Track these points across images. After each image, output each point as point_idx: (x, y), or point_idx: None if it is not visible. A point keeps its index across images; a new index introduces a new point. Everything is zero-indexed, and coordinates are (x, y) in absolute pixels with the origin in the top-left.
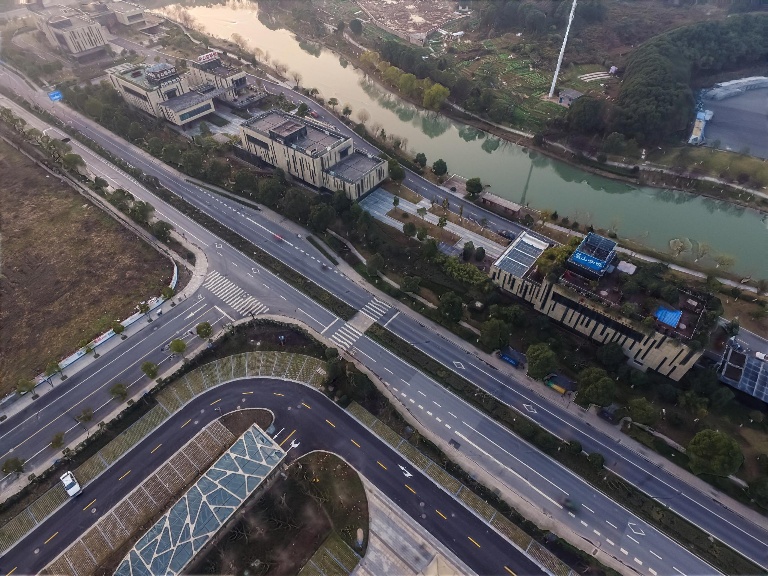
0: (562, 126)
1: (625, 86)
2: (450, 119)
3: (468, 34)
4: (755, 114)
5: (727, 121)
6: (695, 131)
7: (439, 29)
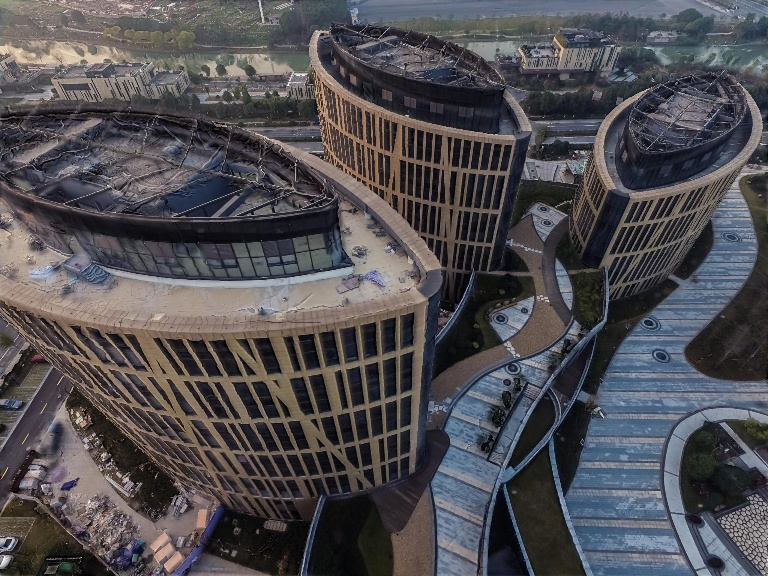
0: (281, 34)
1: (304, 2)
2: (204, 55)
3: (179, 4)
4: (378, 6)
5: (367, 12)
6: (353, 18)
7: (152, 7)
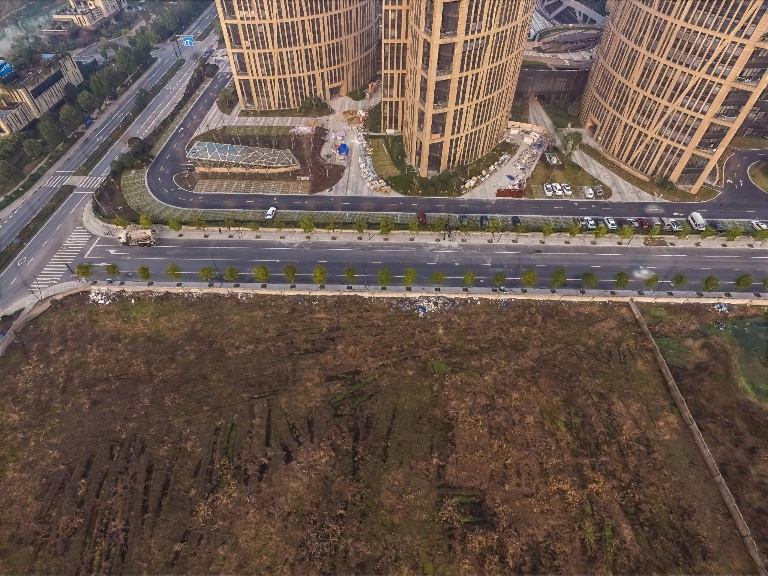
0: None
1: None
2: None
3: None
4: None
5: None
6: None
7: None
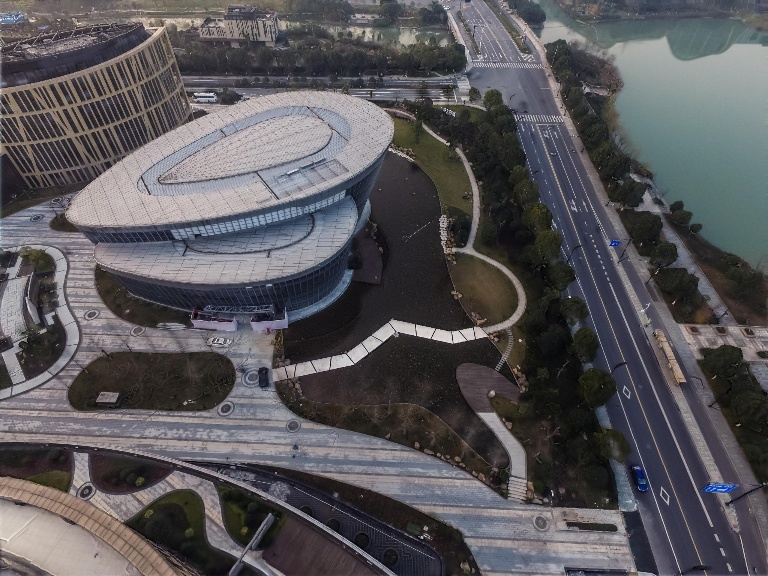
0: (41, 4)
1: None
2: None
3: None
4: None
5: None
6: None
7: None
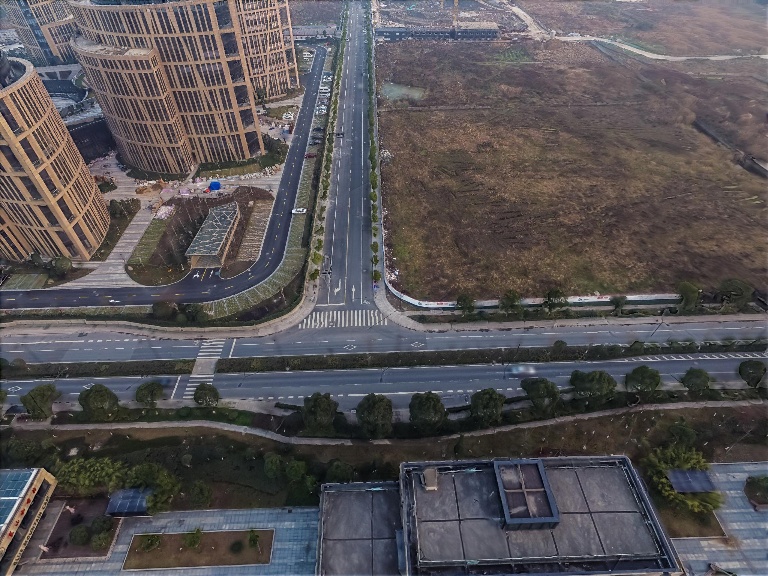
0: None
1: None
2: None
3: None
4: None
5: None
6: None
7: None
